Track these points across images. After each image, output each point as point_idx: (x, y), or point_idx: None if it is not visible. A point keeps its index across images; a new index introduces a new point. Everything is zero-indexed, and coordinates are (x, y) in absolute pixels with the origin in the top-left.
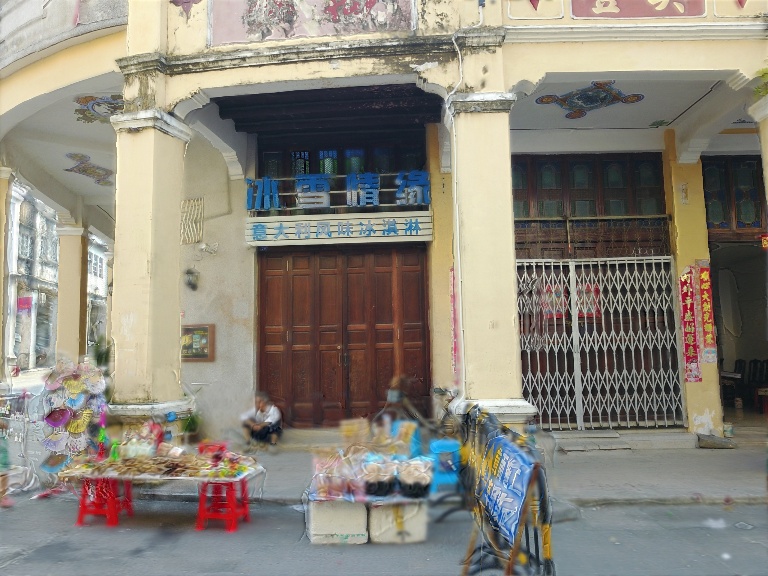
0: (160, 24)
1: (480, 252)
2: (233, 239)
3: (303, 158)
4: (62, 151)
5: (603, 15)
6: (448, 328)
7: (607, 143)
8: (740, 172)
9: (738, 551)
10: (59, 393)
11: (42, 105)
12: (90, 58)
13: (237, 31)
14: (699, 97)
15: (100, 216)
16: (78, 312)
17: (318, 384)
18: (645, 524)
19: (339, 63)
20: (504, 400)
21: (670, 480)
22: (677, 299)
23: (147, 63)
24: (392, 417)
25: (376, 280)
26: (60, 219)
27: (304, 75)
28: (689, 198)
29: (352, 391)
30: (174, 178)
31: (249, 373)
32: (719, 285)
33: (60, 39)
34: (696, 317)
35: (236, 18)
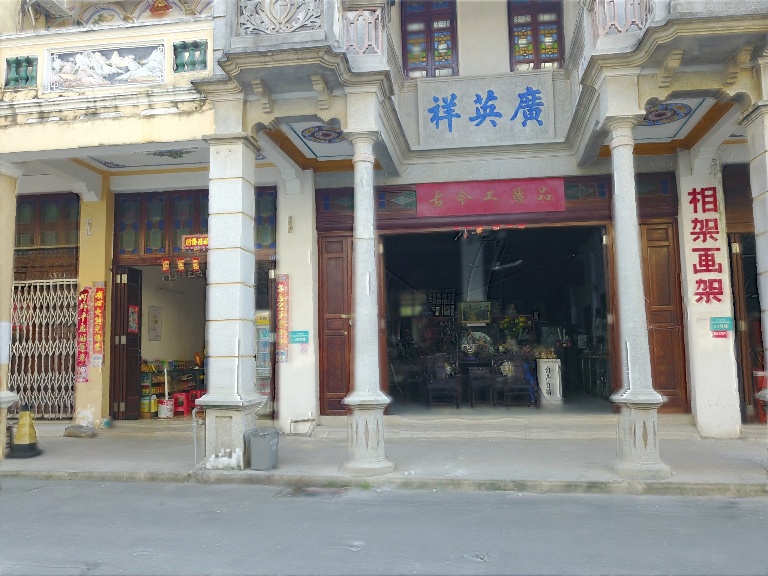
0: None
1: None
2: None
3: None
4: None
5: None
6: None
7: (36, 186)
8: (152, 206)
9: None
10: None
11: None
12: None
13: None
14: None
15: None
16: None
17: None
18: None
19: None
20: None
21: None
22: None
23: None
24: None
25: None
26: None
27: None
28: (92, 230)
29: None
30: None
31: None
32: None
33: None
34: (88, 329)
35: None
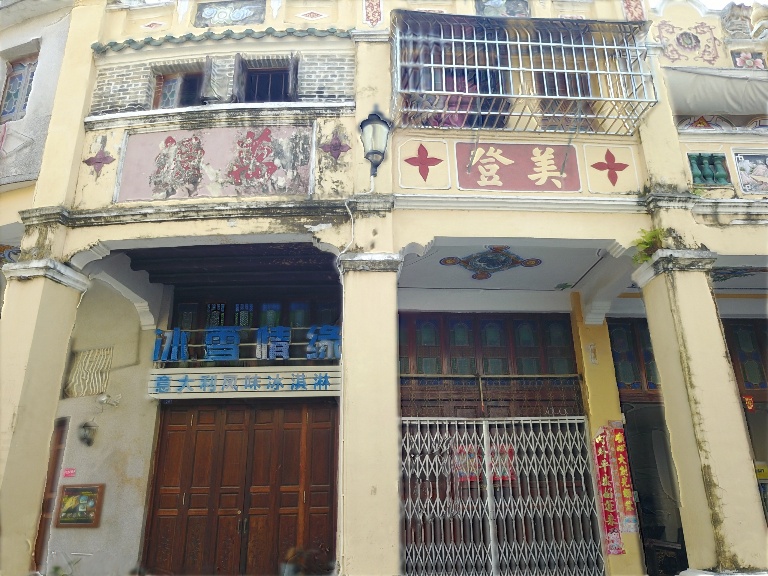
0: (68, 181)
1: (364, 410)
2: (137, 391)
3: (219, 310)
4: None
5: (487, 188)
6: None
7: (516, 303)
8: (646, 334)
9: None
10: None
11: None
12: None
13: (143, 189)
14: (593, 263)
15: None
16: None
17: (213, 555)
18: None
19: (237, 221)
20: None
21: None
22: (593, 462)
23: (49, 215)
24: None
25: (284, 437)
26: None
27: (202, 231)
28: (598, 358)
29: (250, 563)
30: (62, 327)
31: (136, 541)
32: (653, 446)
33: None
34: (614, 481)
35: (144, 178)
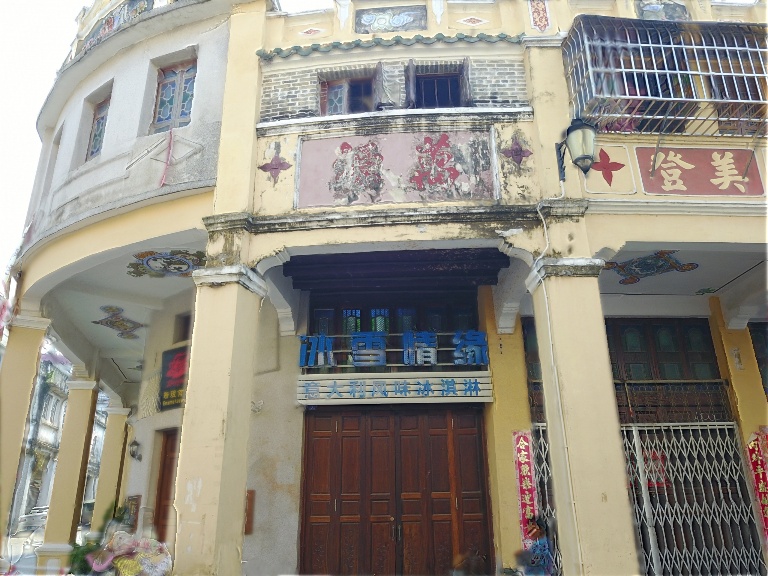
0: (249, 187)
1: (584, 416)
2: (280, 397)
3: (354, 316)
4: (99, 303)
5: (673, 192)
6: (515, 498)
7: (656, 308)
8: None
9: None
10: (111, 575)
11: (109, 258)
12: (172, 215)
13: (323, 195)
14: (749, 268)
15: (111, 369)
16: (78, 474)
17: (369, 562)
18: None
19: (426, 227)
20: None
21: None
22: (748, 468)
23: (235, 222)
24: None
25: (431, 443)
26: (74, 372)
27: (391, 237)
28: (743, 363)
29: (407, 571)
30: (250, 333)
31: (292, 548)
32: None
33: (144, 197)
34: None
35: (323, 184)
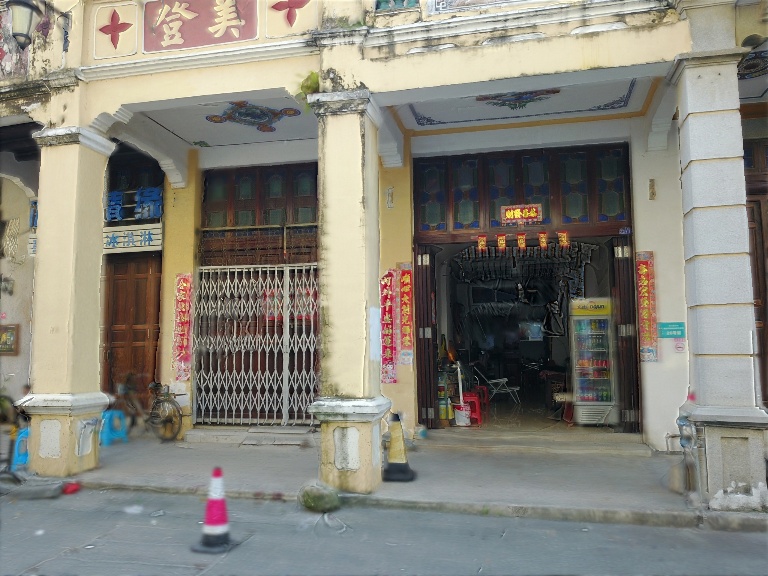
0: None
1: (49, 267)
2: None
3: None
4: None
5: (168, 48)
6: (170, 329)
7: None
8: (461, 172)
9: (78, 531)
10: None
11: None
12: None
13: None
14: None
15: None
16: None
17: None
18: (97, 506)
19: None
20: (54, 395)
21: (232, 473)
22: None
23: None
24: (120, 407)
25: (135, 286)
26: None
27: None
28: (394, 202)
29: (115, 384)
30: None
31: None
32: None
33: None
34: (394, 319)
35: None
